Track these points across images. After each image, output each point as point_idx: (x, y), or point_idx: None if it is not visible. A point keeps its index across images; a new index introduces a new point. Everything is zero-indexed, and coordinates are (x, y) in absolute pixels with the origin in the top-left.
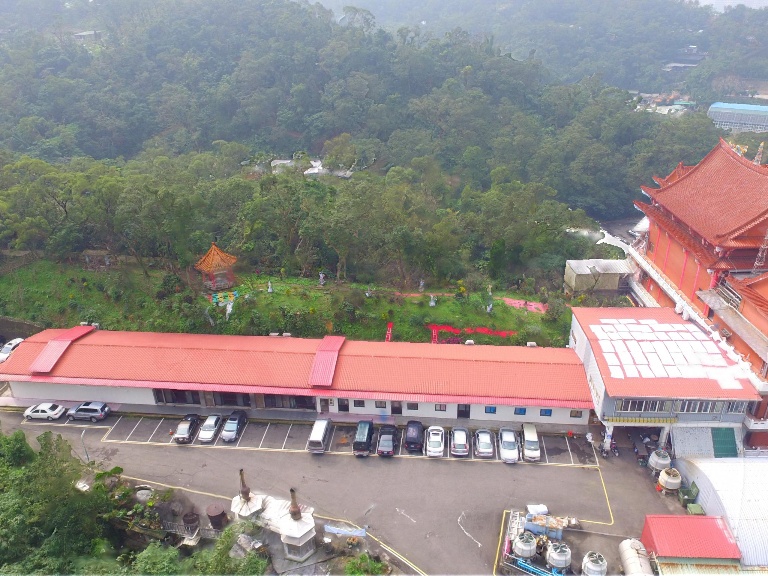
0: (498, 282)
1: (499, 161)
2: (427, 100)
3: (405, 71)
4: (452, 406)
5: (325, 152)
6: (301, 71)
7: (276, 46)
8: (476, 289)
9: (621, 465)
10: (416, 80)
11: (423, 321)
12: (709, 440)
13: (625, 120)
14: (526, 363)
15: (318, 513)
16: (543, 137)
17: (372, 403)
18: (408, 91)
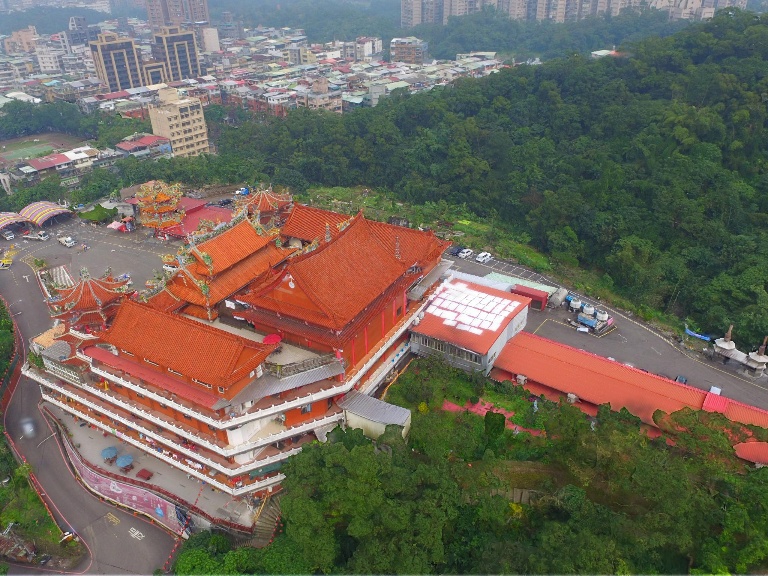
0: None
1: None
2: None
3: None
4: None
5: None
6: None
7: None
8: None
9: None
10: None
11: None
12: None
13: None
14: (547, 355)
15: (711, 367)
16: None
17: None
18: None
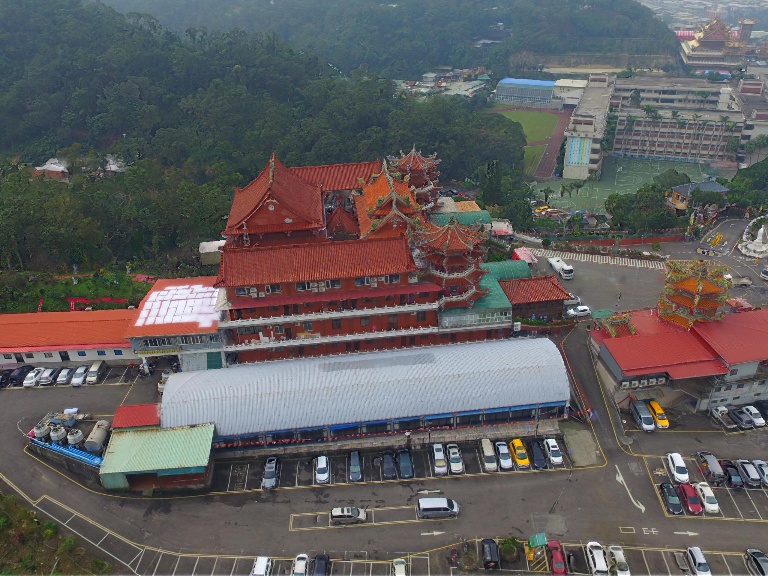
0: (144, 262)
1: (248, 152)
2: (190, 100)
3: (182, 72)
4: (55, 353)
5: (59, 160)
6: (89, 74)
7: (61, 53)
8: (119, 269)
9: (149, 381)
10: (193, 79)
11: (60, 296)
12: (205, 361)
13: (364, 110)
14: (109, 321)
15: None
16: (291, 129)
17: (1, 356)
18: (190, 88)
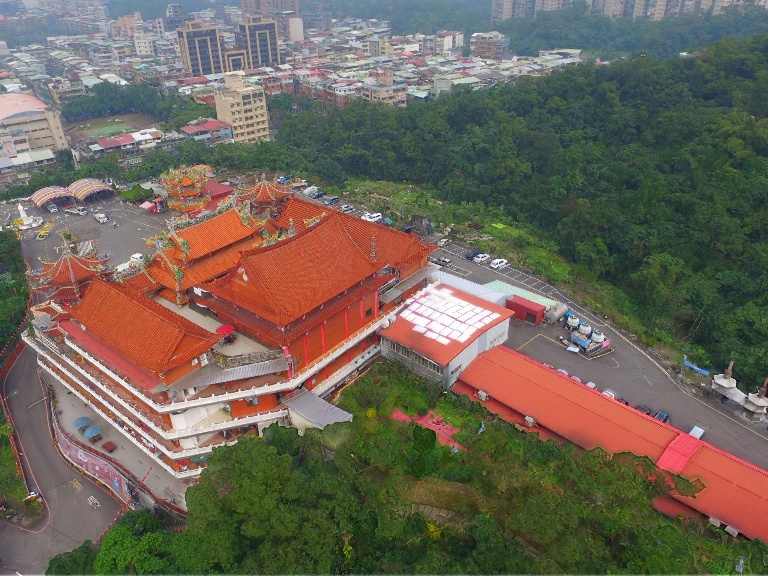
0: None
1: None
2: None
3: None
4: None
5: None
6: None
7: None
8: None
9: None
10: None
11: None
12: None
13: None
14: (515, 373)
15: (705, 405)
16: None
17: None
18: None
